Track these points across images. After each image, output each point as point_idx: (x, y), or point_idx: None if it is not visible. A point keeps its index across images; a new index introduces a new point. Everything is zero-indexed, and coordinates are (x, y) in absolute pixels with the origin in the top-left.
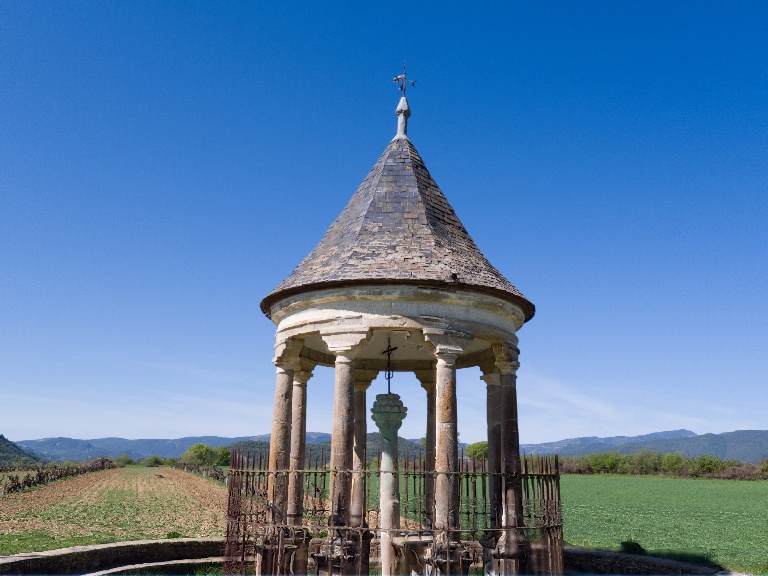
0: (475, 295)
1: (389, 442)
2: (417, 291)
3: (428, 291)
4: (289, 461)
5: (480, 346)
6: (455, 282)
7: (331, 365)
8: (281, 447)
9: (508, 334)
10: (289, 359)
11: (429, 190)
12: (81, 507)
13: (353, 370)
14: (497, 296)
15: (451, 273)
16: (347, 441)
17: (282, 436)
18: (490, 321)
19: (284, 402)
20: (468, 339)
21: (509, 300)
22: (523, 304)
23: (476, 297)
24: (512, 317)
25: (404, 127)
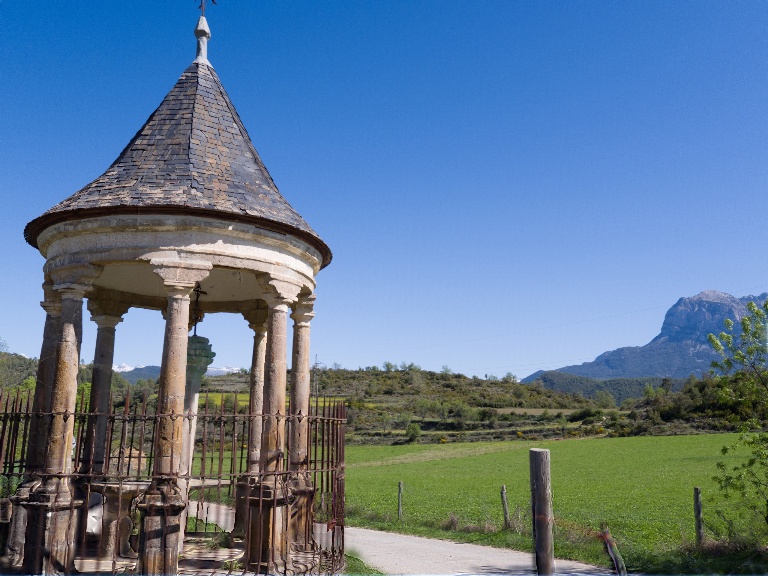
0: None
1: None
2: None
3: None
4: None
5: (111, 284)
6: None
7: (121, 263)
8: None
9: None
10: None
11: None
12: None
13: None
14: None
15: None
16: None
17: None
18: None
19: None
20: None
21: None
22: None
23: None
24: None
25: None
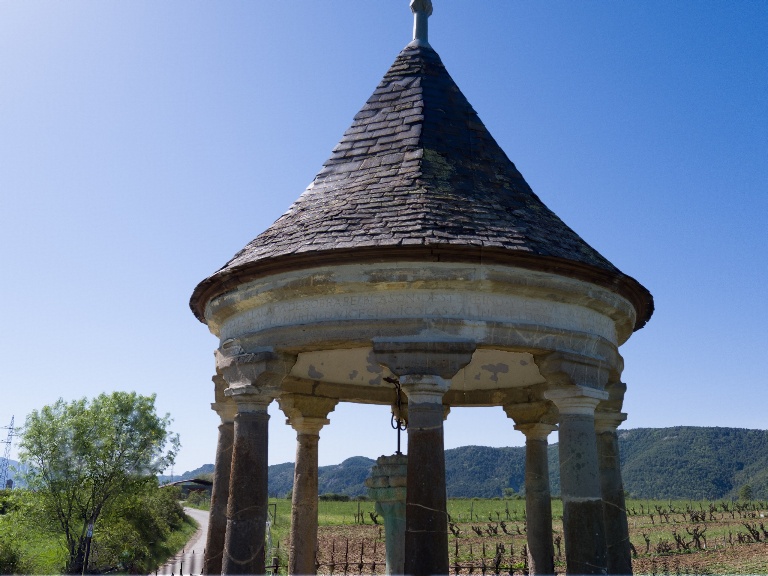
0: (263, 281)
1: (387, 537)
2: (212, 307)
3: (217, 302)
4: (304, 560)
5: None
6: (225, 275)
7: (482, 405)
8: (292, 540)
9: (372, 325)
10: (295, 421)
11: (382, 112)
12: (726, 570)
13: (227, 437)
14: (302, 266)
15: (229, 261)
16: (210, 543)
17: (293, 525)
18: (317, 314)
19: (295, 479)
20: (258, 363)
21: (341, 261)
22: (402, 251)
23: (266, 284)
24: (396, 285)
25: (416, 29)
